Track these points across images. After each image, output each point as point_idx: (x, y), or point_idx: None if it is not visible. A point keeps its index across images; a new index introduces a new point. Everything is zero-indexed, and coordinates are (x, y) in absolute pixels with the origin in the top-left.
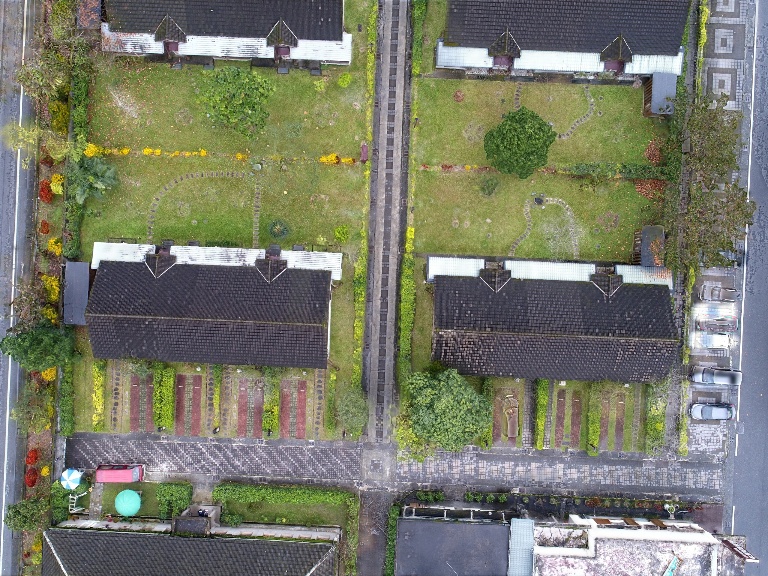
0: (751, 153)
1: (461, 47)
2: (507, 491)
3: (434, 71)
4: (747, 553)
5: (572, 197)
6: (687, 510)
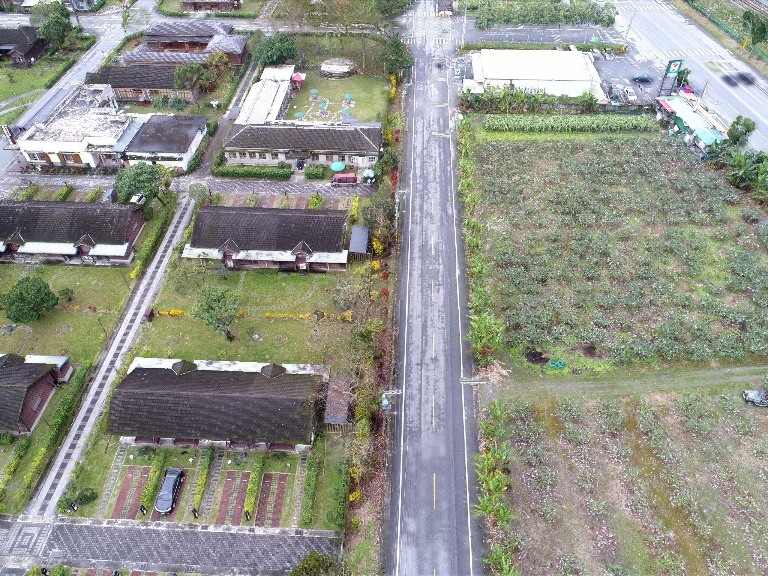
0: None
1: None
2: None
3: (76, 368)
4: (5, 131)
5: None
6: (29, 167)
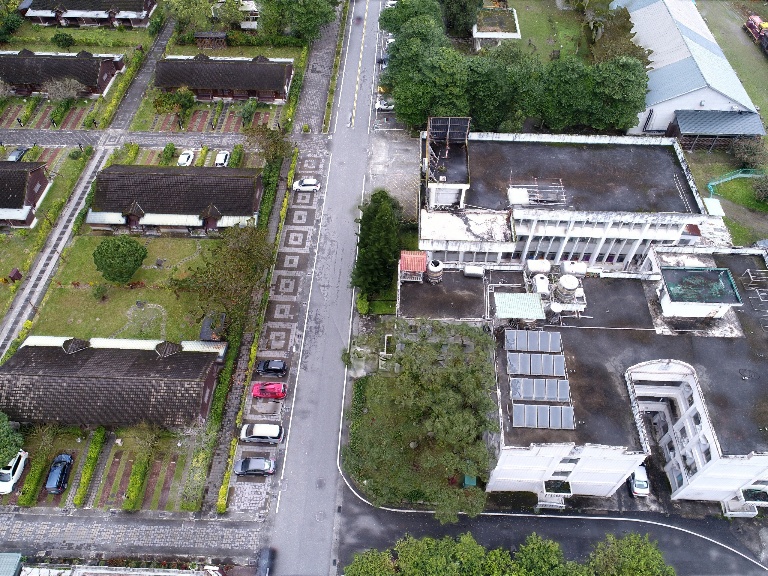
0: (313, 277)
1: (104, 212)
2: (33, 554)
3: (91, 232)
4: None
5: (169, 303)
6: None
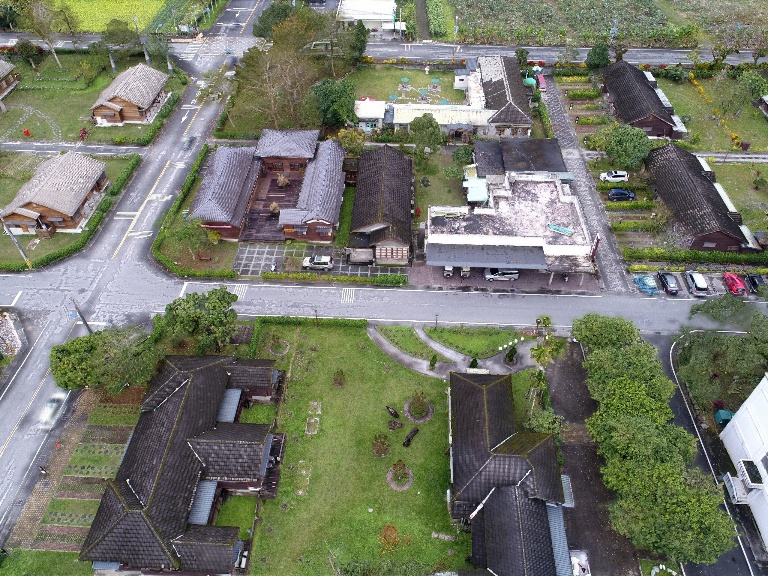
0: None
1: None
2: None
3: None
4: None
5: None
6: None
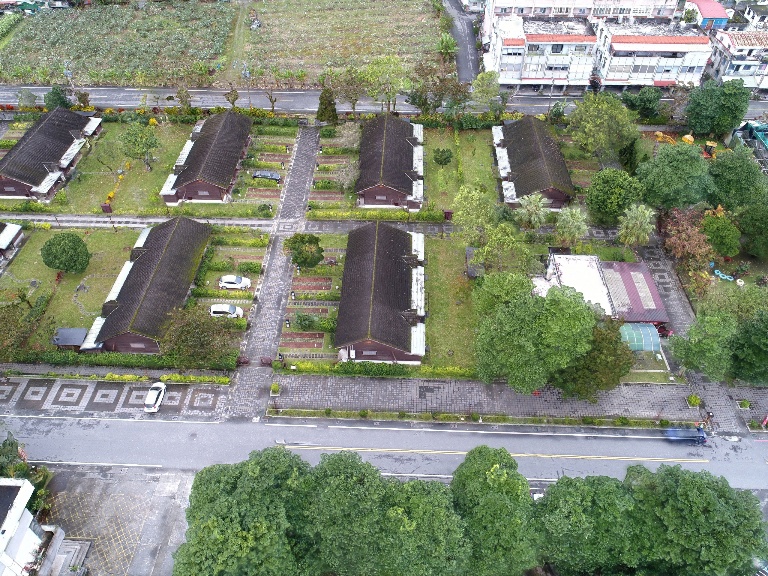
0: (0, 416)
1: None
2: None
3: None
4: None
5: None
6: None
